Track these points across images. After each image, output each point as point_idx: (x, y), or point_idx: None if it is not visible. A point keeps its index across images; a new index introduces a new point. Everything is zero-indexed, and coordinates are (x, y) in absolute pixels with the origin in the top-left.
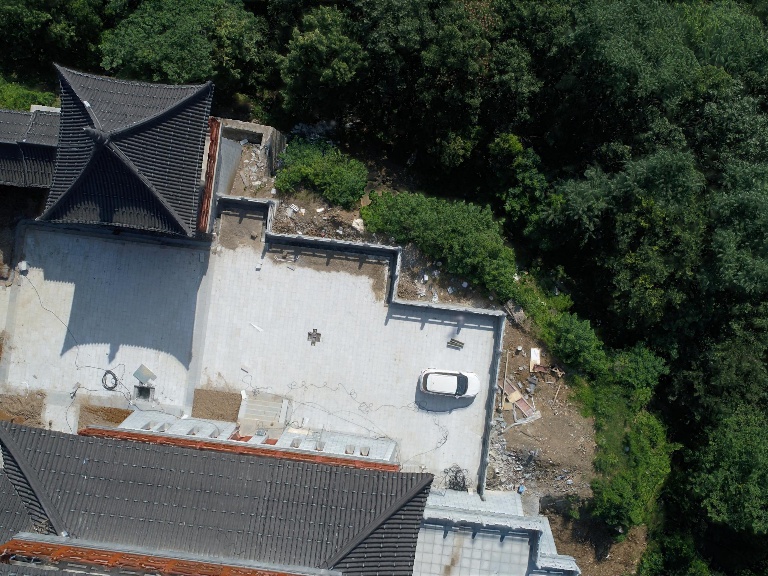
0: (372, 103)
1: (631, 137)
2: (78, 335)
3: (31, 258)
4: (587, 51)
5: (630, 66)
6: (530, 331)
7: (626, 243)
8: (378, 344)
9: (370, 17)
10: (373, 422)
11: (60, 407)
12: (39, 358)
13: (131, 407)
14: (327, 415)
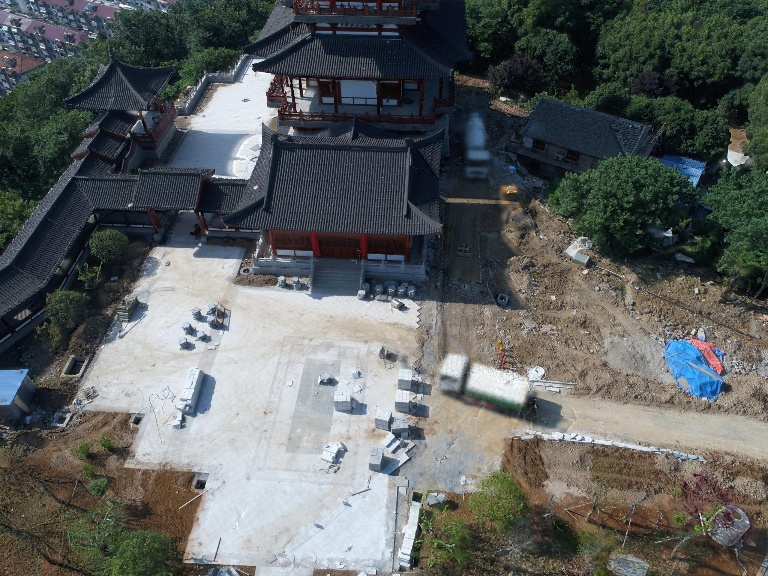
0: None
1: None
2: None
3: None
4: None
5: (143, 16)
6: None
7: None
8: None
9: None
10: None
11: None
12: None
13: None
14: None
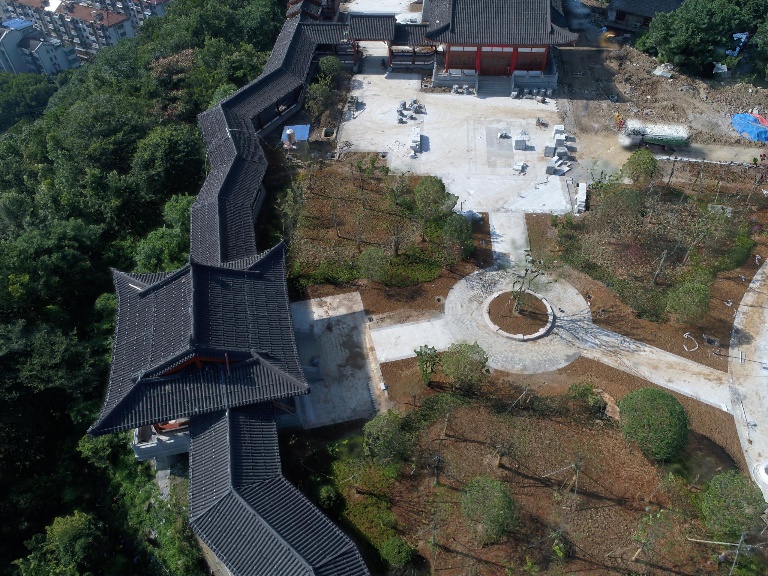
0: None
1: None
2: None
3: None
4: None
5: None
6: None
7: None
8: None
9: None
10: None
11: None
12: None
13: None
14: None
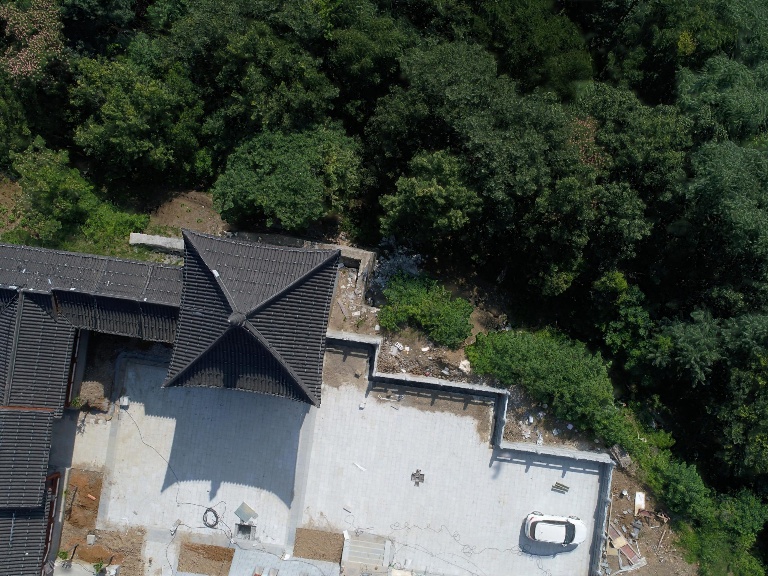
0: (466, 223)
1: (739, 279)
2: (179, 471)
3: (132, 392)
4: (701, 197)
5: None
6: (636, 475)
7: (742, 399)
8: (482, 486)
9: (488, 166)
10: (476, 565)
11: (160, 544)
12: (139, 494)
13: (232, 545)
14: (430, 557)
